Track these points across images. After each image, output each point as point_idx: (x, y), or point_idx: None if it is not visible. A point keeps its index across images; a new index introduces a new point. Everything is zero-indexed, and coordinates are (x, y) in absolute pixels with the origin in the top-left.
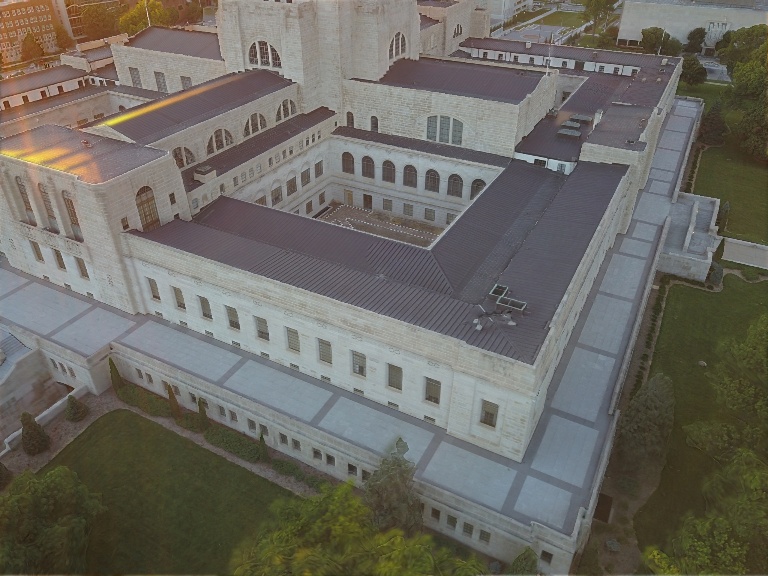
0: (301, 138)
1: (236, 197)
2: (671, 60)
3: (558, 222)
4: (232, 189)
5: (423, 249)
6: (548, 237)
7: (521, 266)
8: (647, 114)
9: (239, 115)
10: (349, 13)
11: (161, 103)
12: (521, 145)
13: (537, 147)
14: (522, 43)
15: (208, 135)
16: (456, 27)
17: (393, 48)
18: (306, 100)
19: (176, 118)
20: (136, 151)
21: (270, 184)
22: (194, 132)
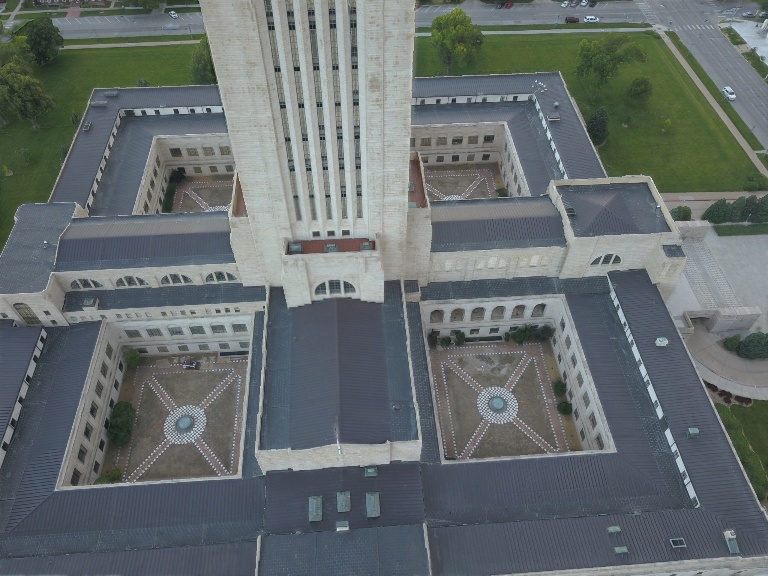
0: (208, 307)
1: (120, 324)
2: (765, 541)
3: (106, 569)
4: (115, 319)
5: (55, 486)
6: (74, 571)
7: (19, 568)
8: (398, 575)
9: (154, 272)
10: (276, 245)
11: (137, 225)
12: (281, 473)
13: (281, 489)
14: (674, 330)
15: (116, 277)
16: (603, 256)
17: (326, 288)
18: (243, 278)
19: (106, 254)
20: (45, 273)
21: (164, 325)
22: (100, 274)
